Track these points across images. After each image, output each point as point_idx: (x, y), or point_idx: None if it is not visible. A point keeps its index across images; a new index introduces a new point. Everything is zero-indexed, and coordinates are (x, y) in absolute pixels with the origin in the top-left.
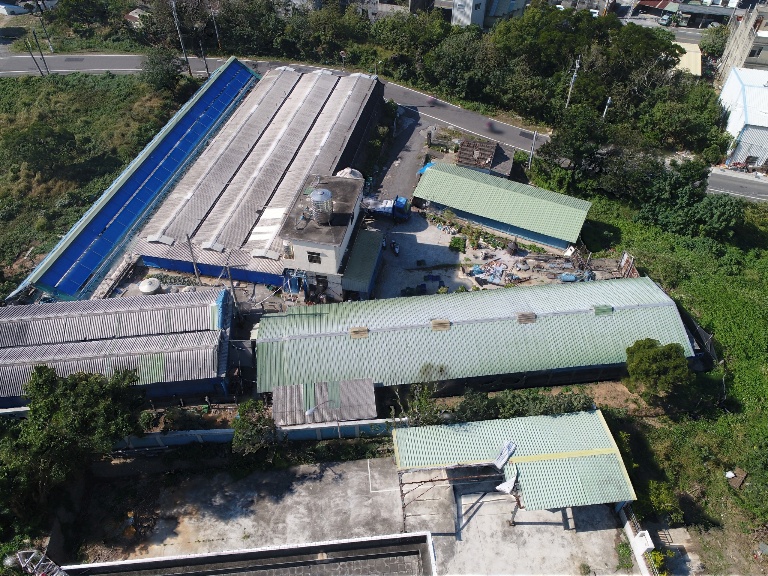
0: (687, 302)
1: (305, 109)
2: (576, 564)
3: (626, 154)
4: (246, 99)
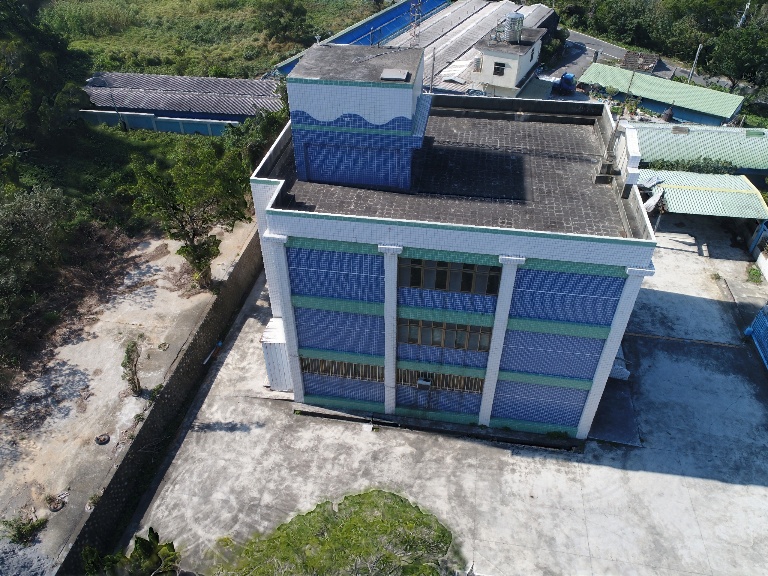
0: None
1: (491, 18)
2: (708, 273)
3: None
4: (441, 11)
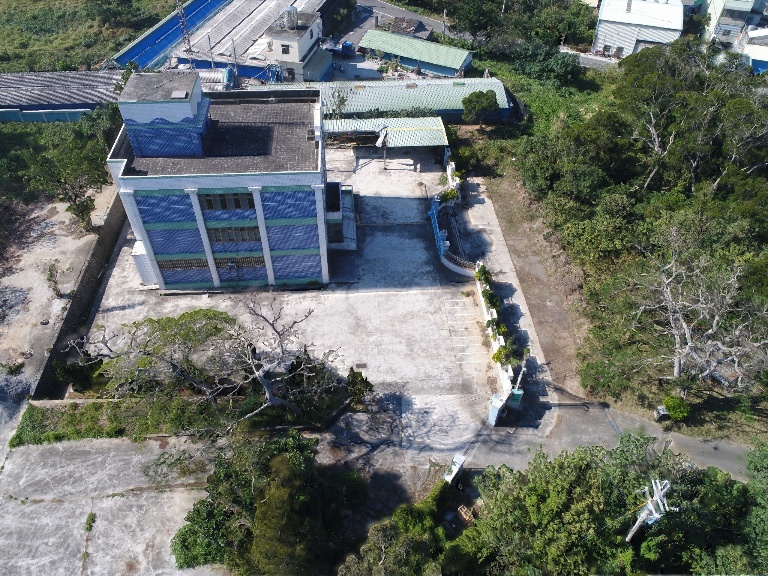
0: (520, 96)
1: None
2: (416, 182)
3: (505, 26)
4: None
